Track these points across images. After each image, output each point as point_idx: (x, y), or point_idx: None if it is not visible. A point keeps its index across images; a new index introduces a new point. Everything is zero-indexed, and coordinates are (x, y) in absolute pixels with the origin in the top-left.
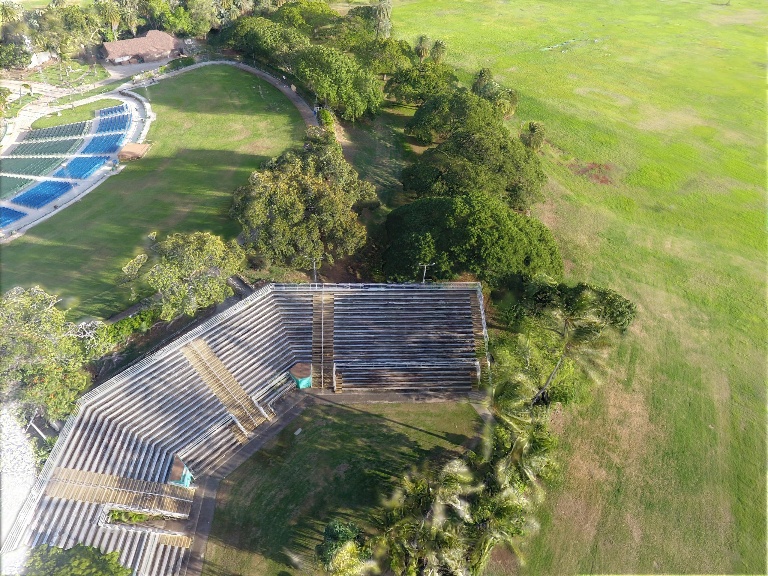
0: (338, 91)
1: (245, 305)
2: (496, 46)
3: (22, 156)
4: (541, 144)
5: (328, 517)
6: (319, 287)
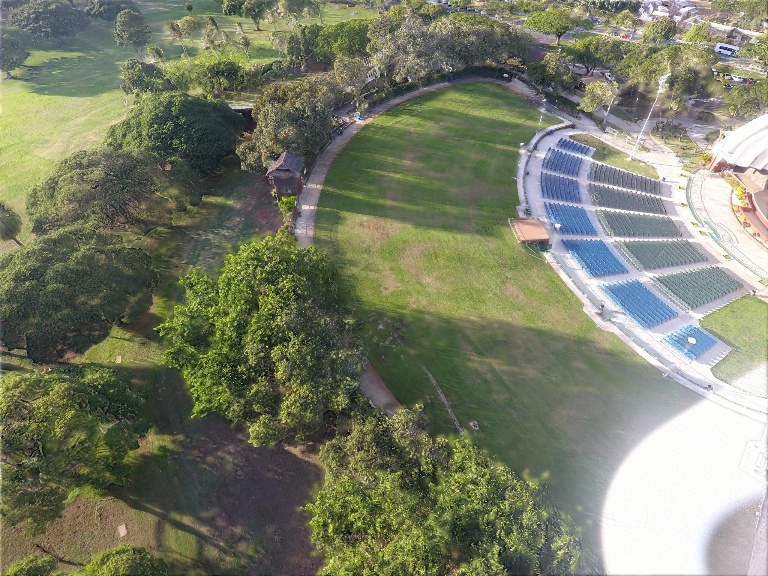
0: None
1: None
2: None
3: None
4: None
5: None
6: None
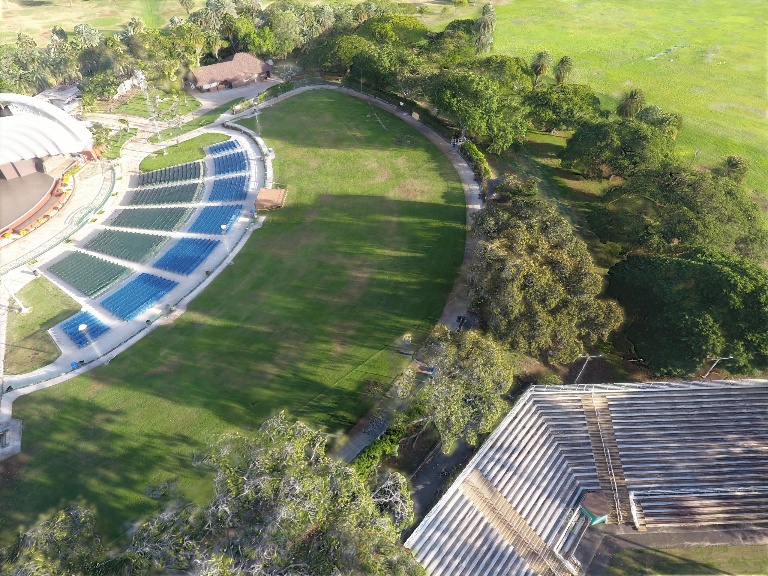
0: (487, 122)
1: (509, 417)
2: (596, 56)
3: (143, 206)
4: (741, 181)
5: None
6: (587, 388)
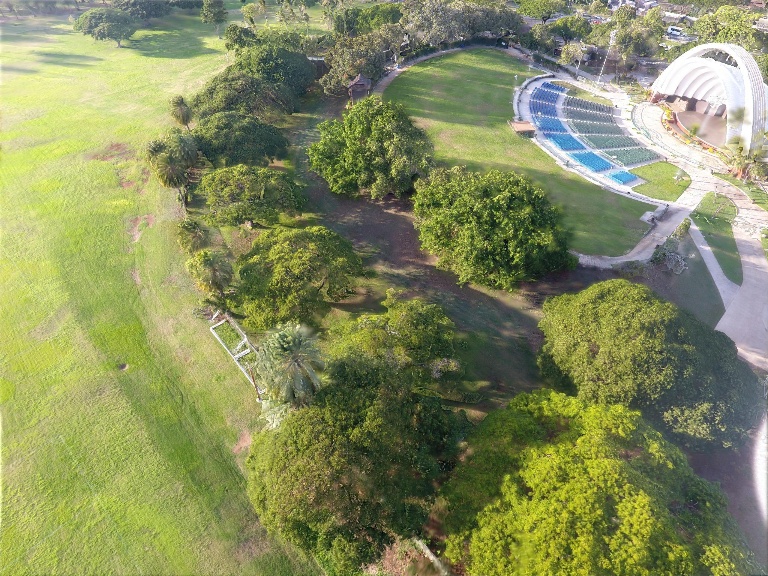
0: None
1: None
2: None
3: None
4: None
5: None
6: None
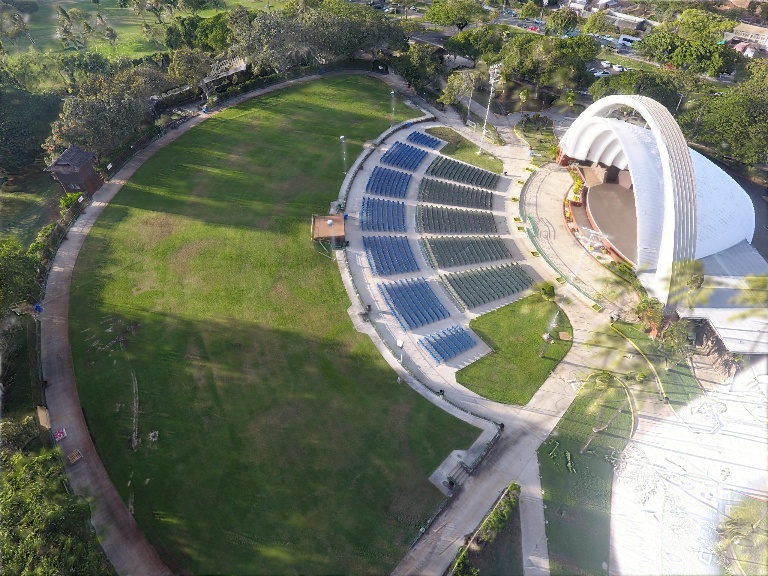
0: None
1: (176, 93)
2: None
3: None
4: None
5: None
6: None
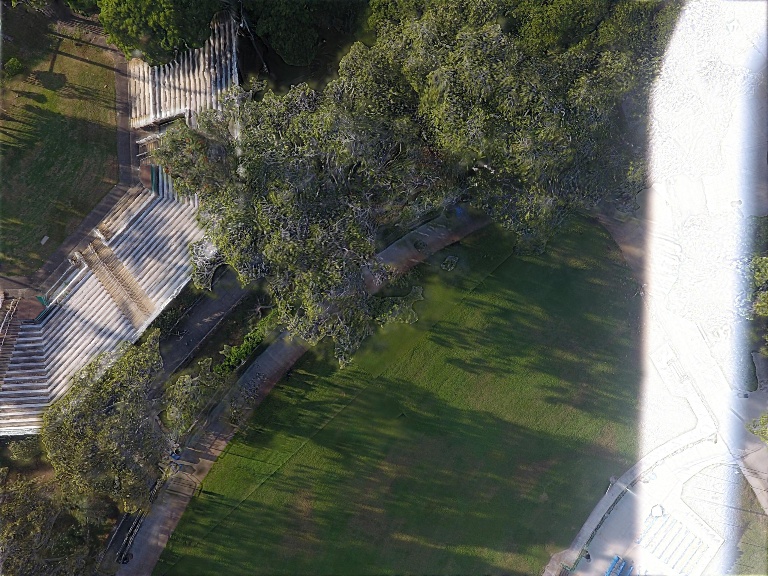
0: None
1: None
2: None
3: None
4: None
5: (4, 150)
6: None
